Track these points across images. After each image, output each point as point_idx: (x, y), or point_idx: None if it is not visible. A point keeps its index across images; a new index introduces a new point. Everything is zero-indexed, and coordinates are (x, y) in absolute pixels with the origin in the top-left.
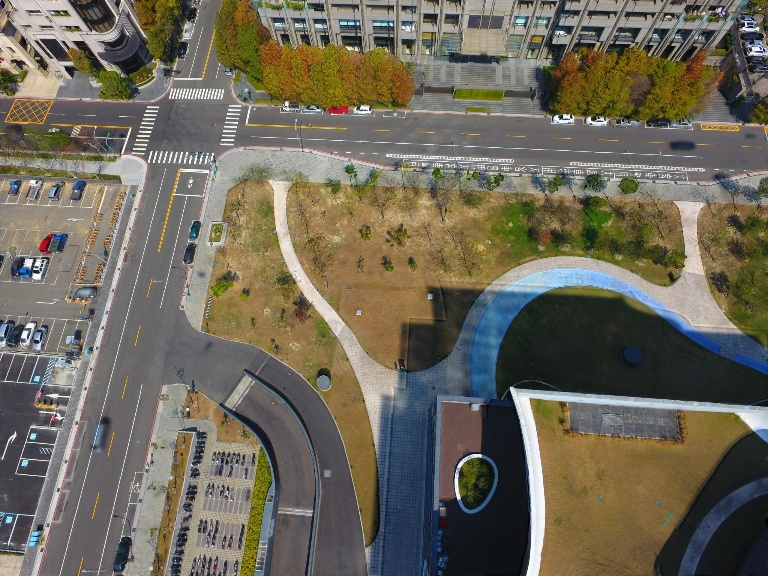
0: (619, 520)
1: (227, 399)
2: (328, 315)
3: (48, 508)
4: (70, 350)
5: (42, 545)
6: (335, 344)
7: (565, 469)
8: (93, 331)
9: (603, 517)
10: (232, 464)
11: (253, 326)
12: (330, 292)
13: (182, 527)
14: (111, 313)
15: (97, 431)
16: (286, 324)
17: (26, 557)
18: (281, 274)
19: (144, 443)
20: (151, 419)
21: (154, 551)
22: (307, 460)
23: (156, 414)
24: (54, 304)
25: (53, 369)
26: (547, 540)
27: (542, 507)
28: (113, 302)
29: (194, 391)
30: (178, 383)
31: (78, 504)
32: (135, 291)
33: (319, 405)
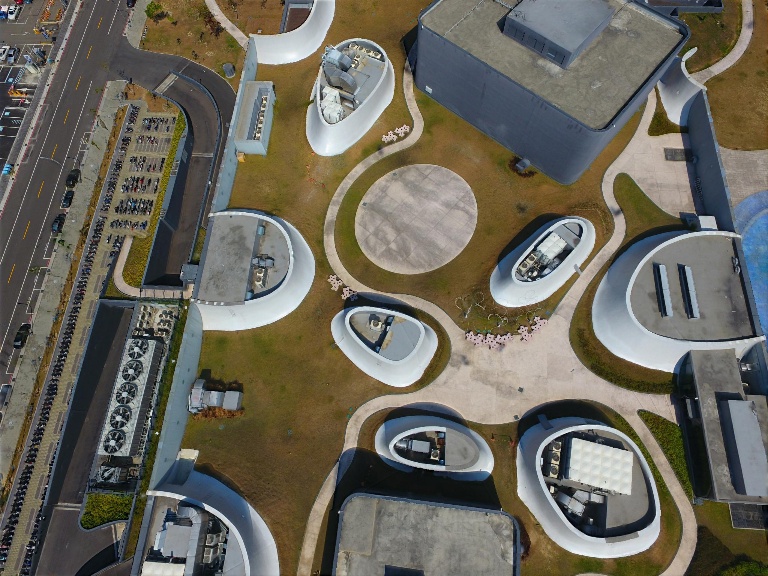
0: (383, 23)
1: (156, 88)
2: (236, 34)
3: (18, 155)
4: (37, 62)
5: (13, 176)
6: (240, 51)
7: (353, 1)
8: (55, 50)
9: (373, 22)
10: (158, 123)
11: (179, 43)
12: (239, 21)
13: (118, 161)
14: (69, 39)
15: (56, 109)
16: (204, 41)
17: (1, 183)
18: (202, 12)
19: (92, 115)
20: (98, 101)
21: (97, 176)
22: (215, 124)
23: (102, 98)
24: (25, 35)
25: (23, 74)
26: (333, 27)
27: (332, 12)
28: (71, 33)
29: (131, 83)
30: (119, 80)
31: (41, 152)
32: (88, 25)
33: (225, 87)
